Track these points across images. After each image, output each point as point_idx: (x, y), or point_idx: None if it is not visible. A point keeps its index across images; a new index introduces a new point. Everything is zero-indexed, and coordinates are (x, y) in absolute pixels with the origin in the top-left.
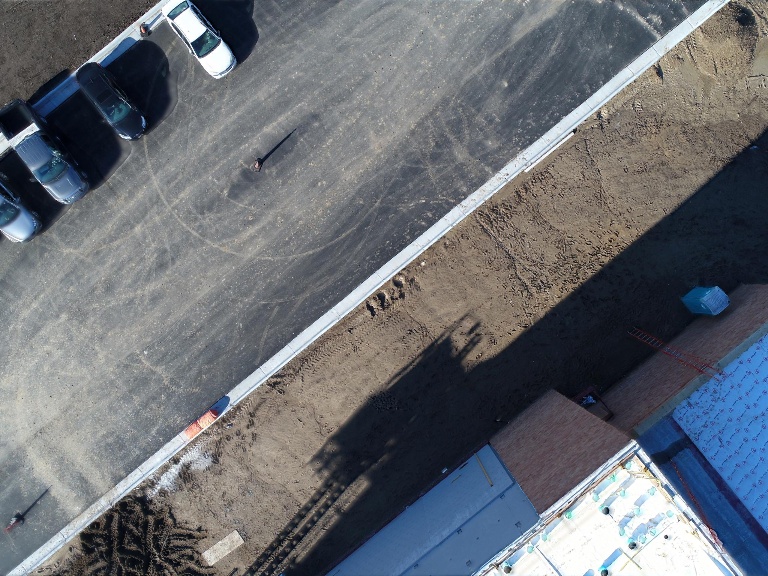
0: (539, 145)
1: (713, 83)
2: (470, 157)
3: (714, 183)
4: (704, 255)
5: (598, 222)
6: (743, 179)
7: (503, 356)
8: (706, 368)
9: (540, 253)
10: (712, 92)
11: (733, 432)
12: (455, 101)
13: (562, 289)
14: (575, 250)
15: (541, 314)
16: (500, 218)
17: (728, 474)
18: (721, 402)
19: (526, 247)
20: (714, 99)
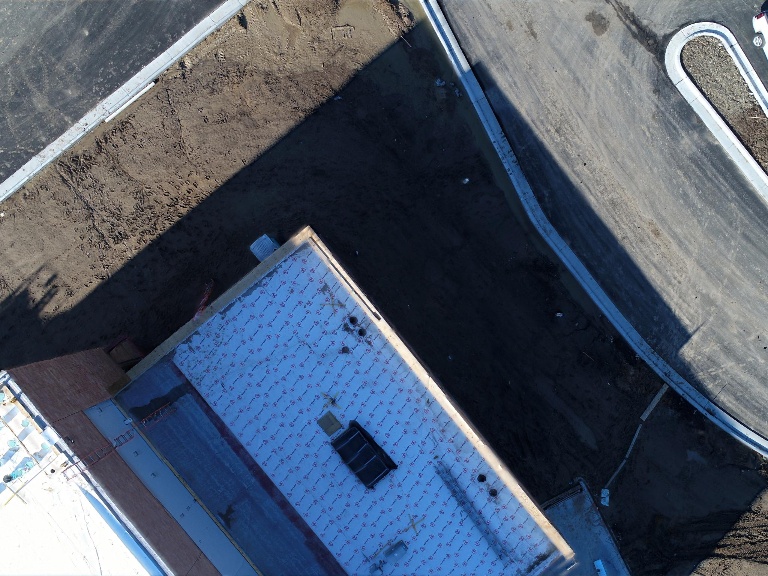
0: (119, 95)
1: (298, 33)
2: (50, 107)
3: (295, 134)
4: (283, 206)
5: (176, 173)
6: (326, 130)
7: (80, 308)
8: (199, 311)
9: (118, 204)
10: (297, 42)
11: (236, 377)
12: (35, 50)
13: (139, 240)
14: (153, 201)
15: (119, 266)
16: (79, 169)
17: (231, 420)
18: (224, 347)
19: (104, 198)
20: (299, 49)
